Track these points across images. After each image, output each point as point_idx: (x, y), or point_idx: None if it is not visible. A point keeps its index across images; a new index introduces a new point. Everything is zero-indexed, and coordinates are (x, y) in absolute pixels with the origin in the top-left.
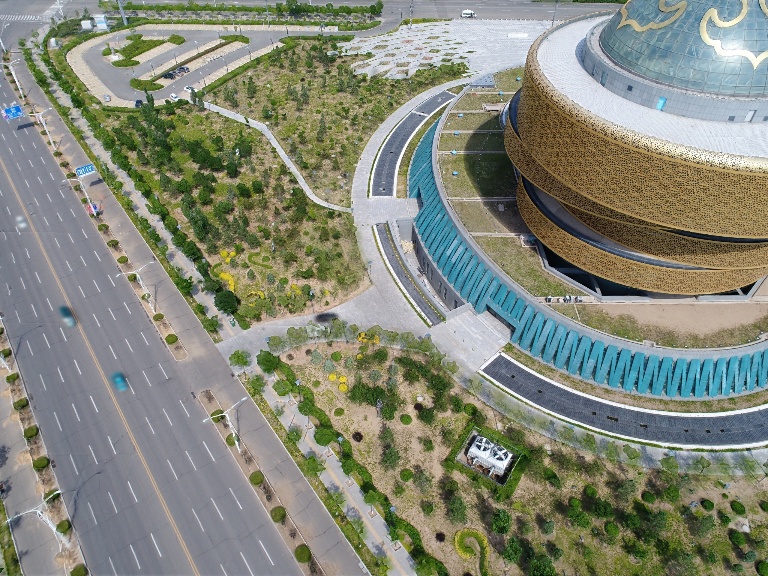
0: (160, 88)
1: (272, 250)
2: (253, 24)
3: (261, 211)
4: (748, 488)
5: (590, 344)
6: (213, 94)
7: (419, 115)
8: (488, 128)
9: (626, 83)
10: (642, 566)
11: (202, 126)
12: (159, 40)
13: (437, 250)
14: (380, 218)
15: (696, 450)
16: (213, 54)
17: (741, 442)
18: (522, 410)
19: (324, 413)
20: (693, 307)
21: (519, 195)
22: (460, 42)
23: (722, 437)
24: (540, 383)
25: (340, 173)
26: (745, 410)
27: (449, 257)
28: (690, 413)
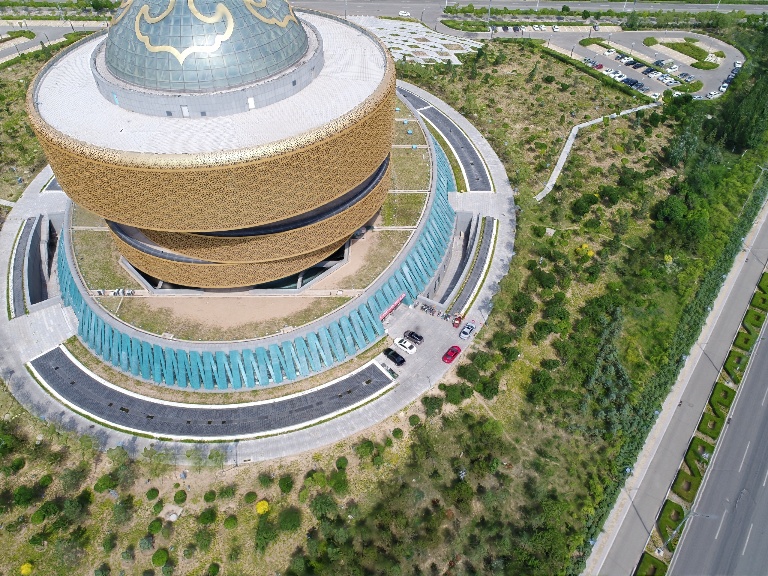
0: None
1: None
2: (50, 19)
3: None
4: (207, 478)
5: (120, 336)
6: None
7: None
8: None
9: None
10: (43, 553)
11: None
12: None
13: None
14: (37, 212)
15: (183, 441)
16: None
17: (233, 433)
18: (42, 401)
19: None
20: (238, 301)
21: None
22: None
23: (218, 428)
24: (78, 375)
25: (30, 168)
26: (260, 402)
27: (60, 251)
28: (203, 405)
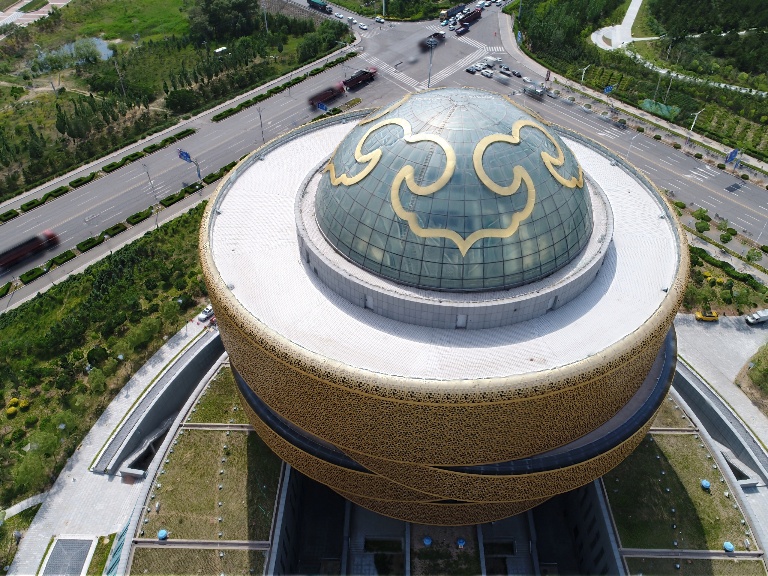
0: None
1: None
2: None
3: None
4: None
5: None
6: None
7: None
8: None
9: None
10: None
11: None
12: None
13: None
14: None
15: None
16: None
17: None
18: None
19: (711, 260)
20: None
21: None
22: None
23: None
24: None
25: None
26: None
27: None
28: None
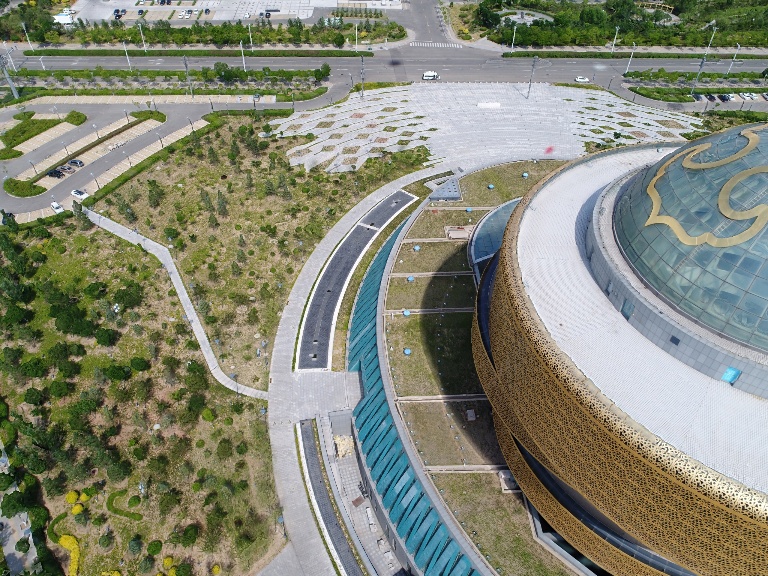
0: (41, 192)
1: (146, 481)
2: (174, 94)
3: (141, 403)
4: None
5: None
6: (107, 201)
7: (367, 229)
8: (452, 268)
9: (668, 331)
10: None
11: (84, 254)
12: (53, 120)
13: (382, 477)
14: (307, 409)
15: None
16: (118, 138)
17: None
18: None
19: None
20: None
21: (496, 415)
22: (421, 115)
23: None
24: None
25: (258, 328)
26: None
27: (398, 496)
28: None
